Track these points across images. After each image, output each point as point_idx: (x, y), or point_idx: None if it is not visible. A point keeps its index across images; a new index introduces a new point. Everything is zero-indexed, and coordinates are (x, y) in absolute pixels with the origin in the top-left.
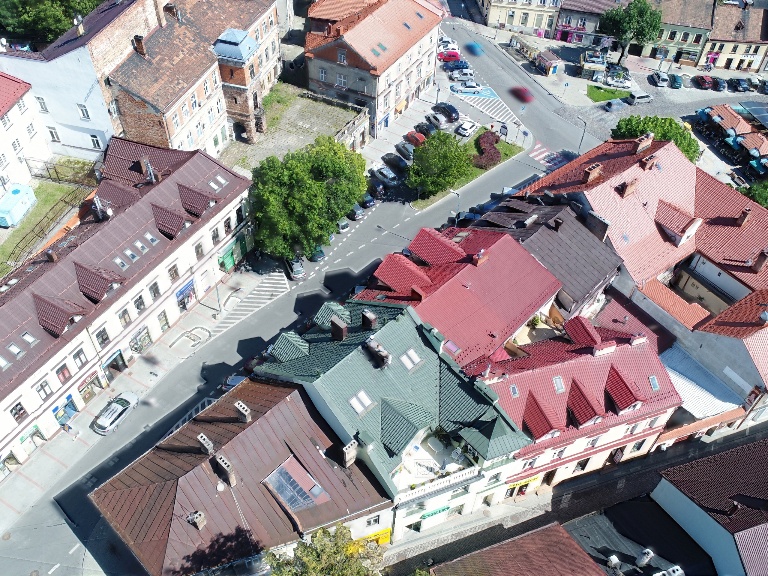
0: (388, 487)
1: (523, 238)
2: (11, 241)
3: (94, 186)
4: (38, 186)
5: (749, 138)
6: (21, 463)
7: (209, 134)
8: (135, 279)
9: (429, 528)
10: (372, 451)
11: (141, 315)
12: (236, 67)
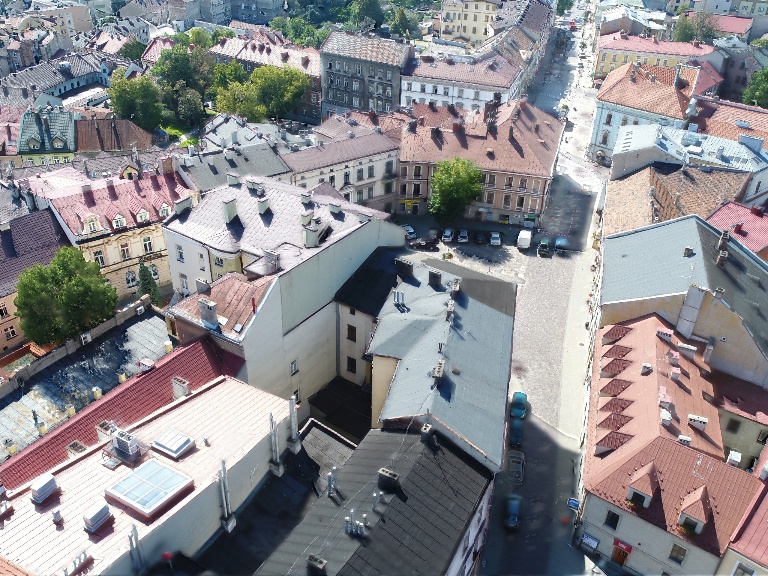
0: None
1: None
2: None
3: None
4: None
5: None
6: None
7: None
8: None
9: None
10: None
11: None
12: None
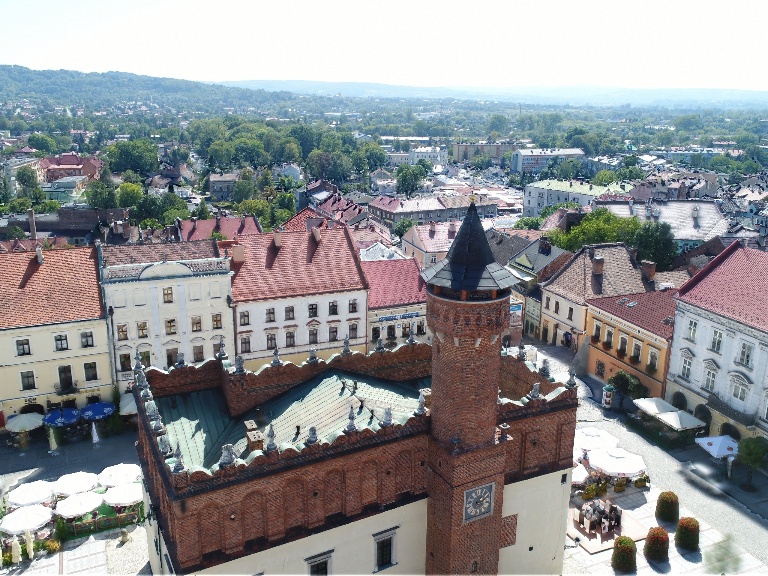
0: None
1: None
2: None
3: None
4: None
5: None
6: None
7: None
8: None
9: None
10: None
11: None
12: None
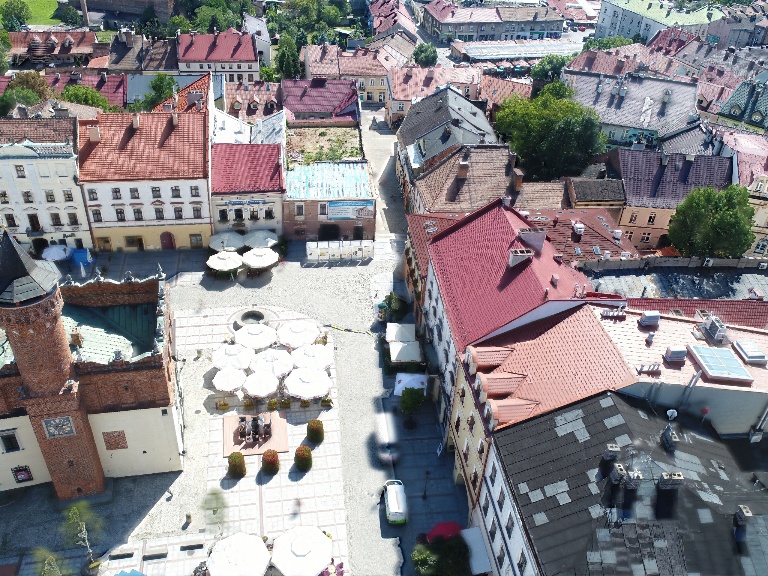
0: None
1: None
2: None
3: None
4: None
5: (504, 64)
6: None
7: None
8: None
9: None
10: None
11: None
12: None
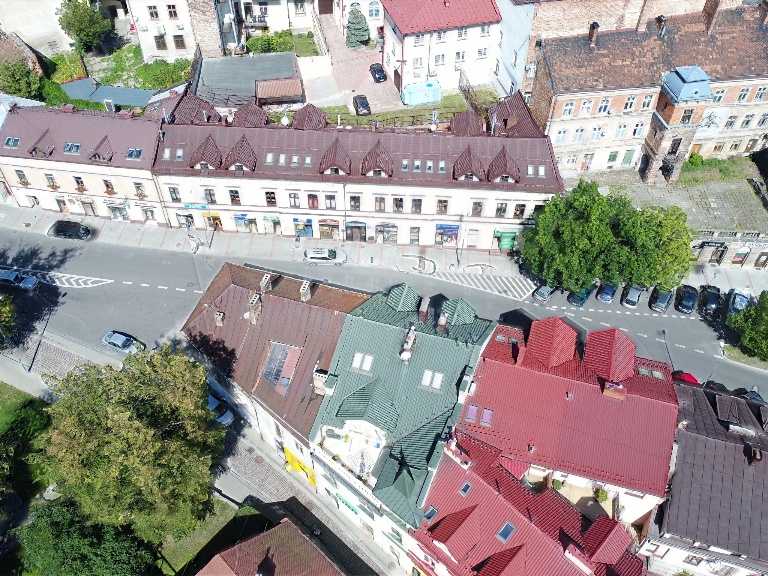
0: (312, 429)
1: (703, 432)
2: (396, 113)
3: (479, 117)
4: (454, 94)
5: None
6: (259, 233)
7: (607, 145)
8: (401, 181)
9: (346, 516)
10: (330, 396)
11: (395, 213)
12: (671, 102)
